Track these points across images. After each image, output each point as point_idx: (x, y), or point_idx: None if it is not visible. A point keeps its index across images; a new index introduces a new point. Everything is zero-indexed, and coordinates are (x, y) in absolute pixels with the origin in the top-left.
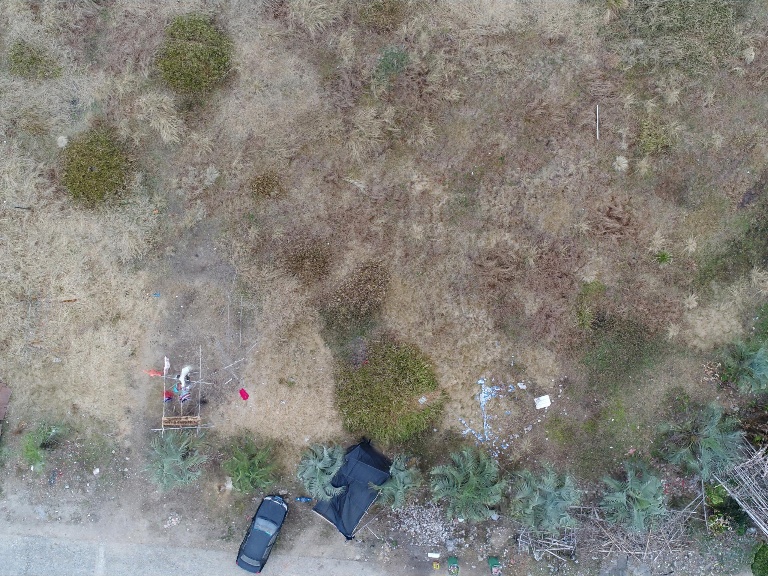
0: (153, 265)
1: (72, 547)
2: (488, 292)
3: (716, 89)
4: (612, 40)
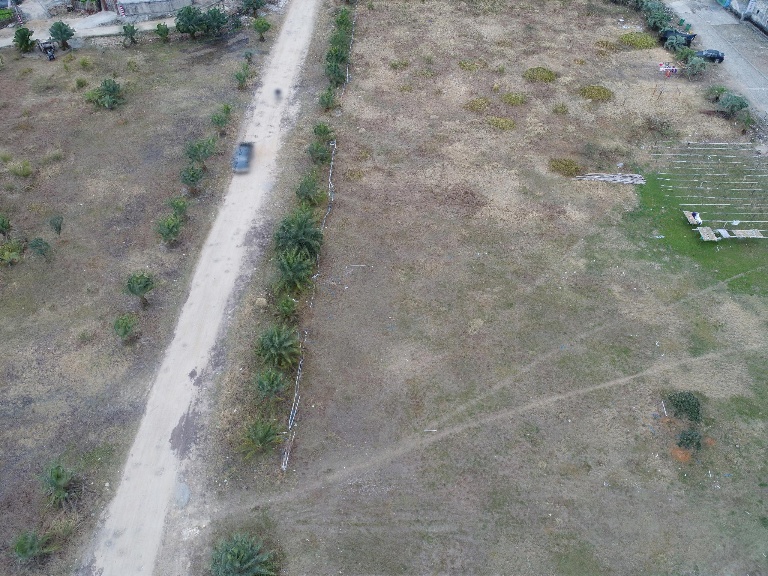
0: (626, 83)
1: None
2: None
3: None
4: None
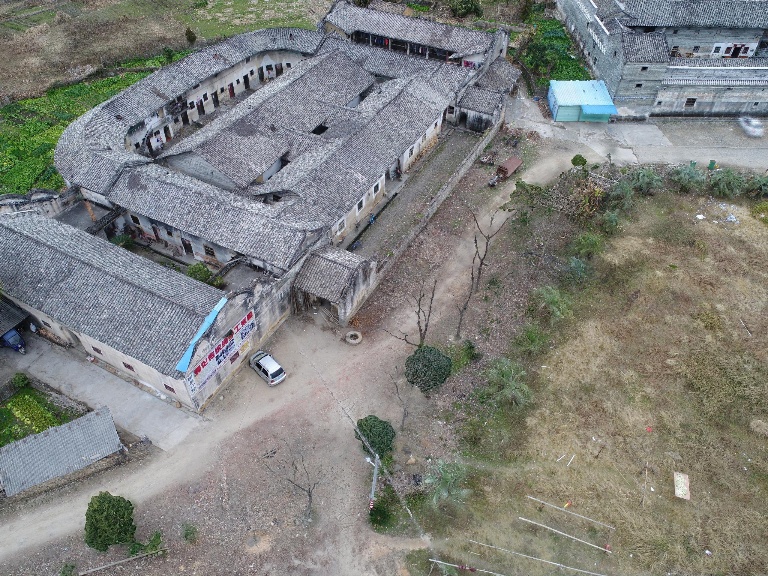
0: None
1: None
2: (759, 253)
3: (681, 346)
4: (765, 369)
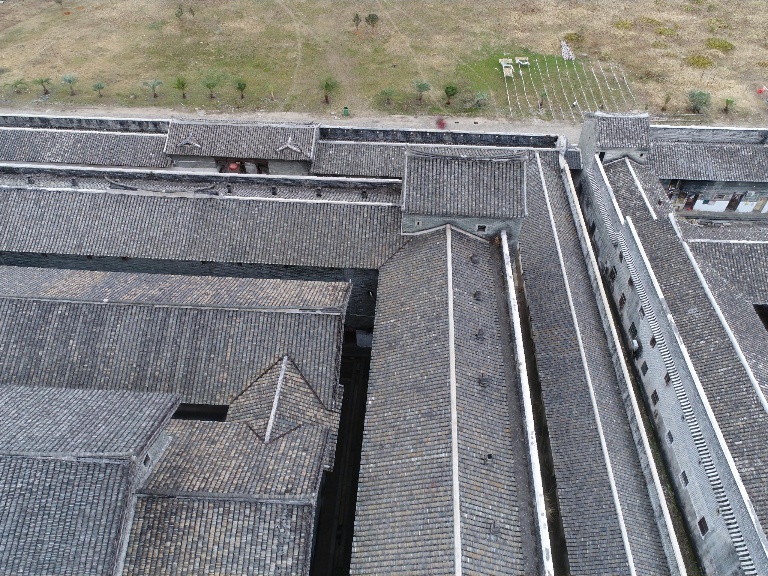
0: None
1: None
2: None
3: None
4: None
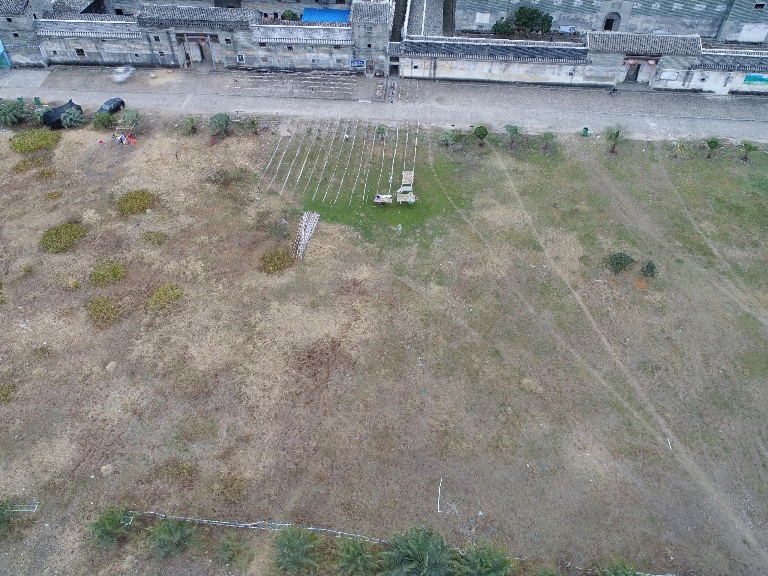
0: None
1: (194, 109)
2: None
3: None
4: None
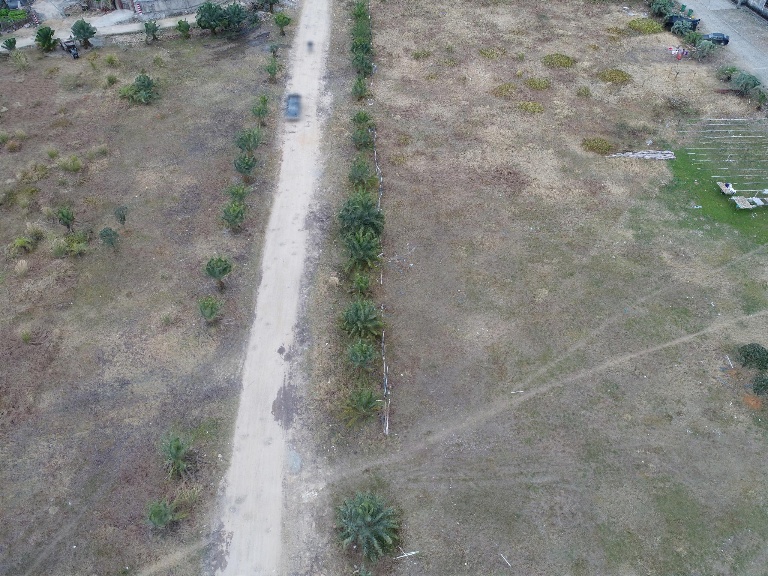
0: (640, 66)
1: None
2: None
3: None
4: (507, 3)
